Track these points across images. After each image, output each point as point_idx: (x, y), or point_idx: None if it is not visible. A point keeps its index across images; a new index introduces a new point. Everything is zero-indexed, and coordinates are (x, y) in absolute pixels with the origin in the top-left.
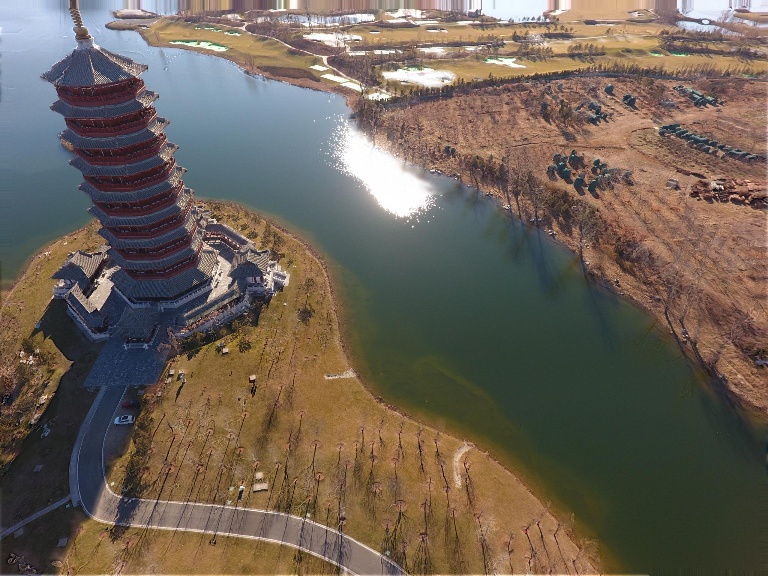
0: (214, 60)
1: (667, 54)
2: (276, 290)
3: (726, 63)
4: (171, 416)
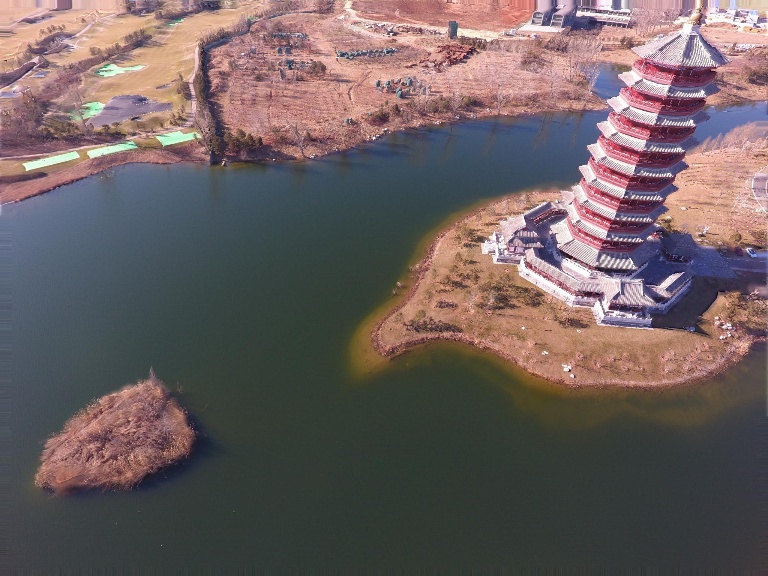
0: None
1: (178, 22)
2: None
3: (207, 17)
4: None
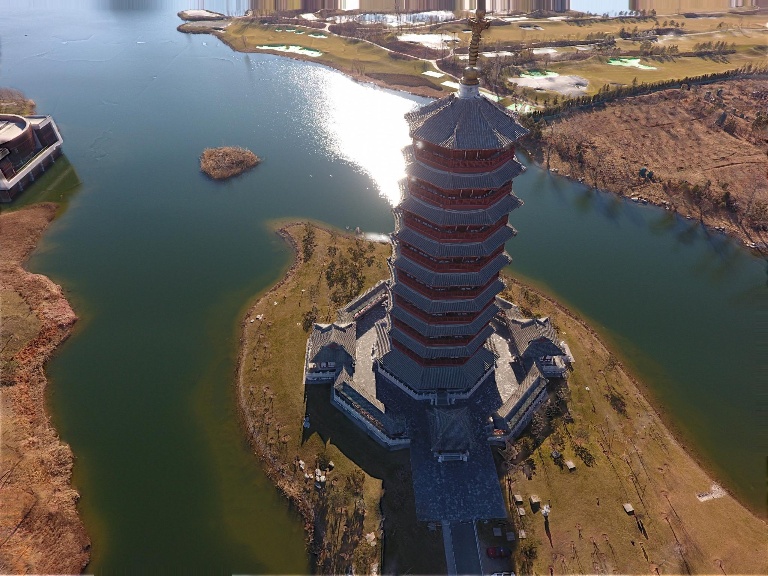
0: (311, 66)
1: None
2: (565, 368)
3: None
4: (561, 571)
